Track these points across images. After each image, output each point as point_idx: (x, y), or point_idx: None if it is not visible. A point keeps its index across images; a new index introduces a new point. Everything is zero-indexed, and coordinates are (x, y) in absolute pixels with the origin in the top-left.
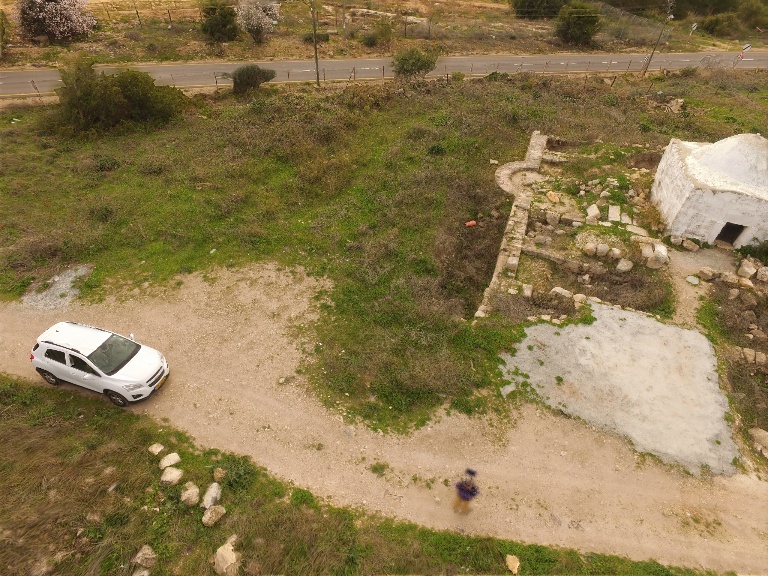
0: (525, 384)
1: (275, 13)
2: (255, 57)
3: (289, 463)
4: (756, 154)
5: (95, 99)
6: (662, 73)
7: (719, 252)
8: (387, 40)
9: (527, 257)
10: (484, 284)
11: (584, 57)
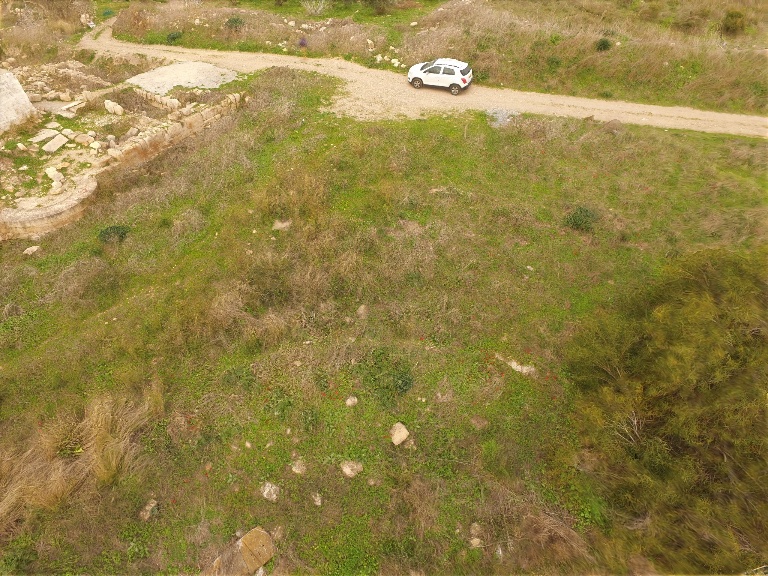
0: (240, 75)
1: None
2: None
3: (352, 66)
4: None
5: None
6: None
7: None
8: None
9: None
10: None
11: None
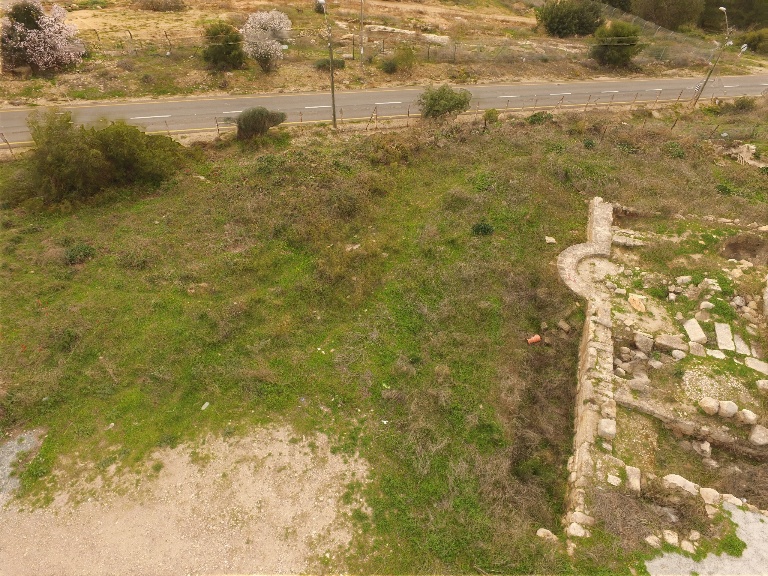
0: None
1: None
2: (263, 88)
3: None
4: None
5: (69, 166)
6: (713, 103)
7: None
8: (408, 65)
9: (621, 410)
10: (566, 450)
11: (625, 83)
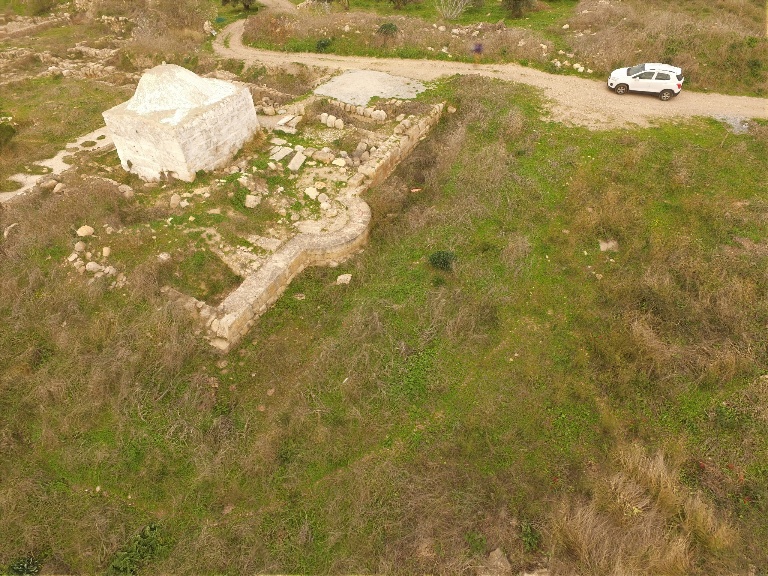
0: None
1: None
2: None
3: (533, 72)
4: None
5: None
6: None
7: None
8: None
9: None
10: None
11: None
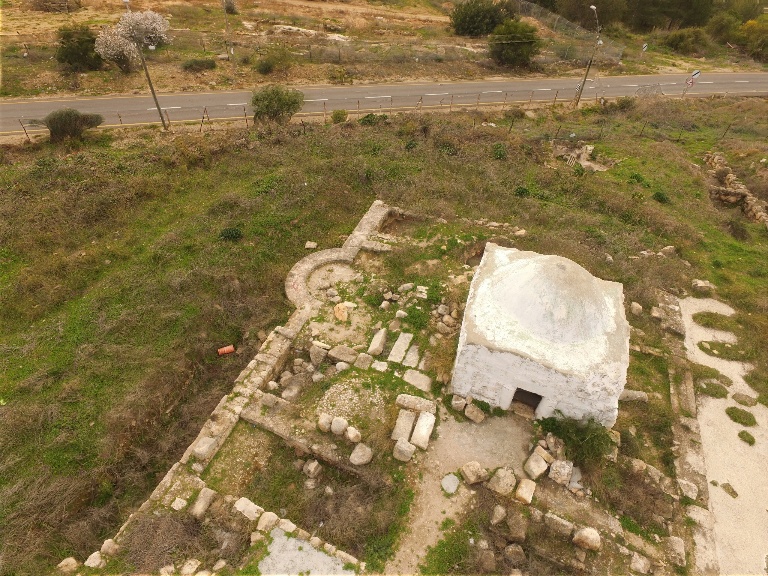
0: None
1: (160, 36)
2: (117, 90)
3: None
4: (553, 295)
5: None
6: (599, 102)
7: (514, 423)
8: (286, 66)
9: (246, 427)
10: None
11: (515, 83)
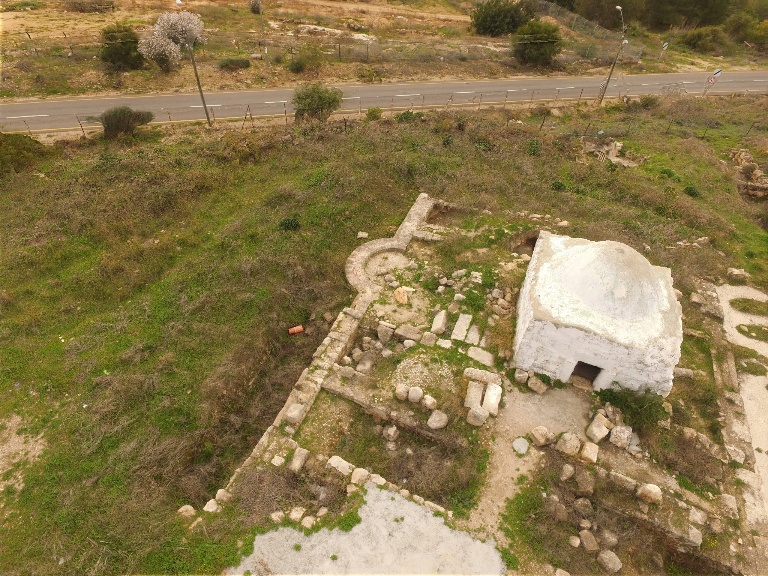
0: None
1: None
2: (158, 88)
3: None
4: (614, 276)
5: None
6: (622, 101)
7: (573, 394)
8: (317, 65)
9: (327, 396)
10: None
11: (538, 81)
